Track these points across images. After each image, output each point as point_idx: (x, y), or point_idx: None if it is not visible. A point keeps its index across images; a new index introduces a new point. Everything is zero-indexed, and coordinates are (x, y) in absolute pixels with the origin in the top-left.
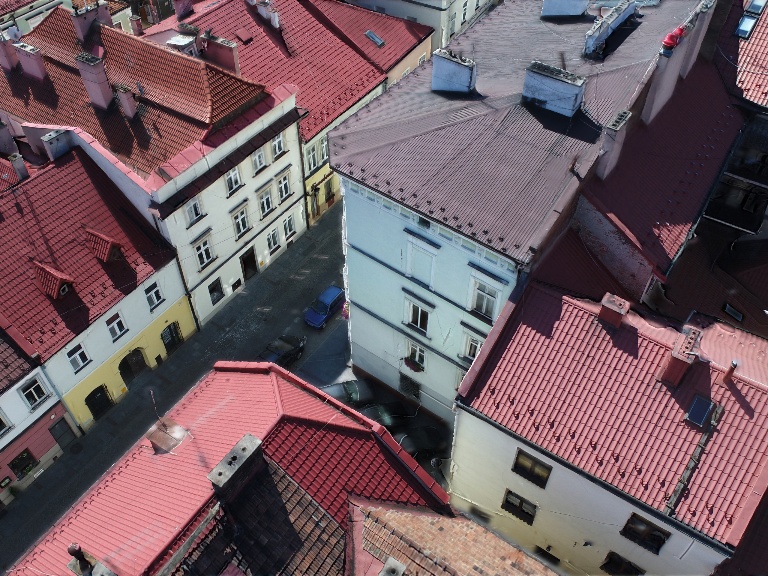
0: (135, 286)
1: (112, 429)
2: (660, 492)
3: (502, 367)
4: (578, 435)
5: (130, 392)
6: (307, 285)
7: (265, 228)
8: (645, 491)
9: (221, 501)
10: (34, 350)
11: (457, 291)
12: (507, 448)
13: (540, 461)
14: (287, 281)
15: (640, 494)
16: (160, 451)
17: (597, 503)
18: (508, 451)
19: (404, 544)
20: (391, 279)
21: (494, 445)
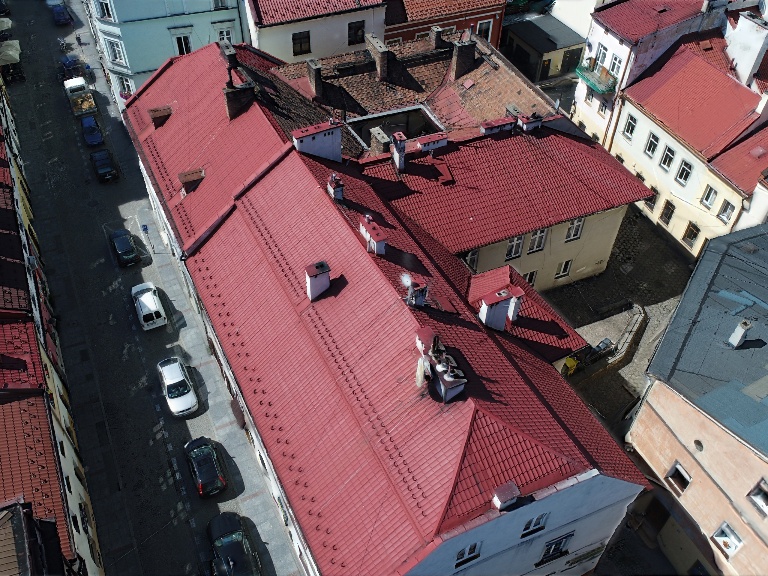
0: (2, 136)
1: (57, 252)
2: (352, 2)
3: (261, 1)
4: (310, 4)
5: (38, 236)
6: (61, 137)
7: (5, 110)
8: (347, 6)
9: (238, 66)
10: (2, 179)
11: (202, 1)
12: (287, 41)
13: (303, 36)
14: (45, 143)
15: (347, 8)
16: (165, 121)
17: (334, 35)
18: (289, 43)
19: (301, 65)
20: (158, 28)
21: (281, 46)
